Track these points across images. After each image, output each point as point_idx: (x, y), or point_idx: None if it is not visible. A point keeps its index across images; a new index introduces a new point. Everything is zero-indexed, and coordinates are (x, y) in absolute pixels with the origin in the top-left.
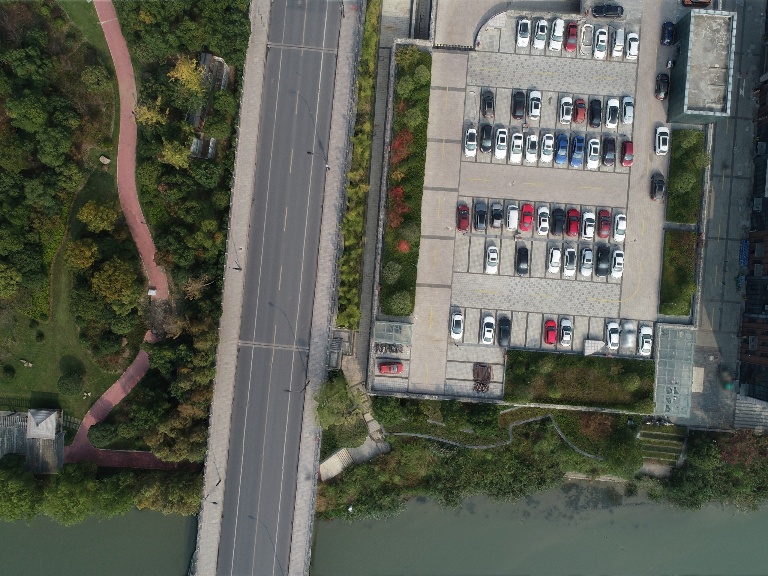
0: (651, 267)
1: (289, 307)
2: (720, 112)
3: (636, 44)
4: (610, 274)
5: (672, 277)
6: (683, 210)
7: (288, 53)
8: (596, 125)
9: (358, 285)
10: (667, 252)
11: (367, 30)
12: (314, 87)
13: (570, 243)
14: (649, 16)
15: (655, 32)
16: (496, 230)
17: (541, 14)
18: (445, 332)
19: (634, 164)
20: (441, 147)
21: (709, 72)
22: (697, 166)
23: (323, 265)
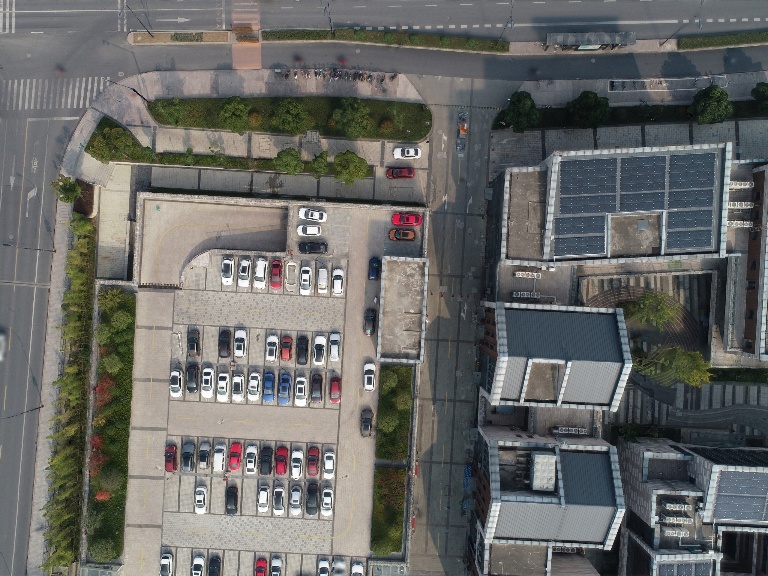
0: (363, 503)
1: (5, 545)
2: (413, 359)
3: (339, 283)
4: (321, 511)
5: (382, 515)
6: (391, 448)
7: (0, 289)
8: (302, 364)
9: (79, 517)
10: (376, 490)
11: (69, 272)
12: (27, 323)
13: (281, 480)
14: (356, 250)
15: (363, 266)
16: (206, 469)
17: (245, 253)
18: (156, 572)
19: (344, 400)
20: (149, 386)
21: (404, 317)
22: (399, 408)
23: (38, 503)
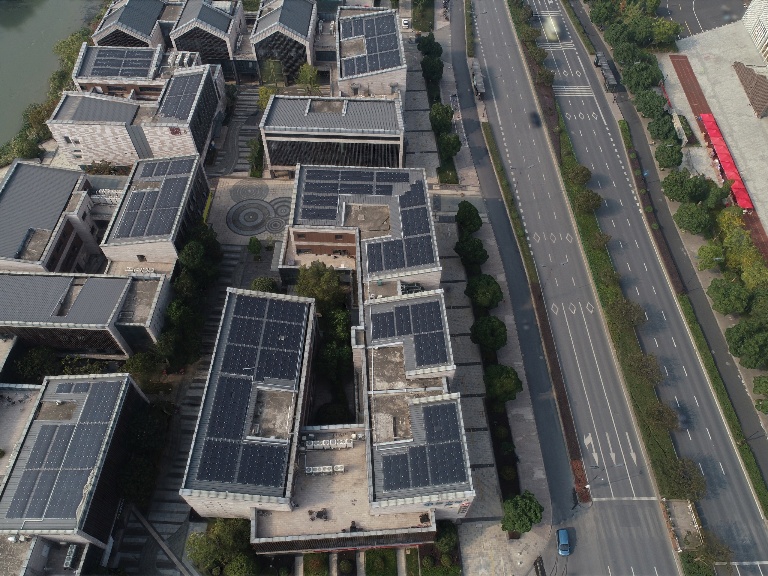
0: None
1: None
2: None
3: None
4: None
5: None
6: None
7: None
8: None
9: None
10: None
11: None
12: None
13: None
14: None
15: None
16: None
17: None
18: None
19: None
20: None
21: None
22: None
23: None
